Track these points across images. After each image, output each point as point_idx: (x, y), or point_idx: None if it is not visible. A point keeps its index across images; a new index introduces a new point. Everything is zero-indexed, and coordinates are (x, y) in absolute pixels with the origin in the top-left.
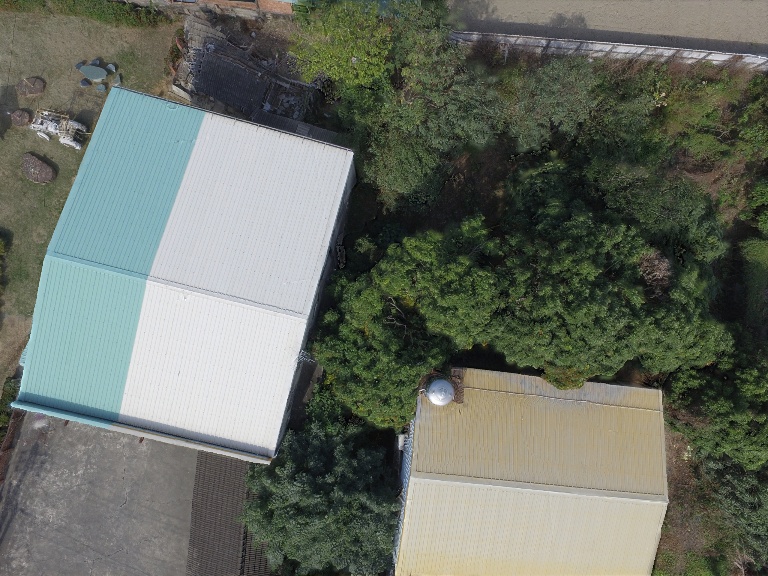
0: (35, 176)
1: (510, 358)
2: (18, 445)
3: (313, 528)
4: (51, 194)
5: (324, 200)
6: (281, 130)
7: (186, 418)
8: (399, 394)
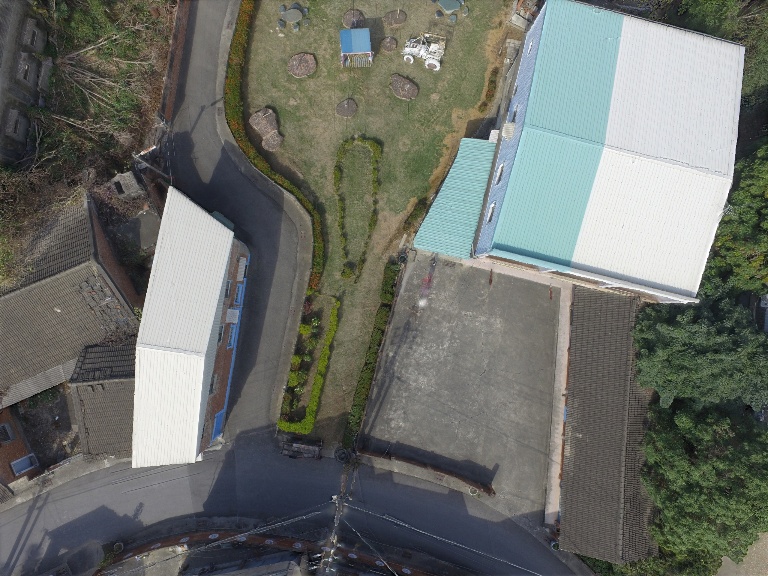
0: (404, 93)
1: None
2: (392, 322)
3: (719, 363)
4: (413, 109)
5: (728, 85)
6: (686, 29)
7: (625, 265)
8: None
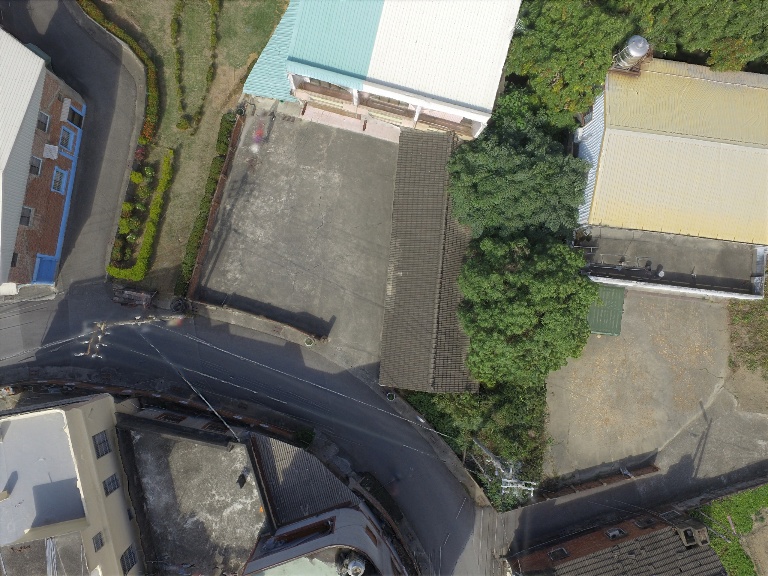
0: None
1: (687, 31)
2: (230, 176)
3: (519, 184)
4: None
5: None
6: None
7: (420, 81)
8: (603, 48)
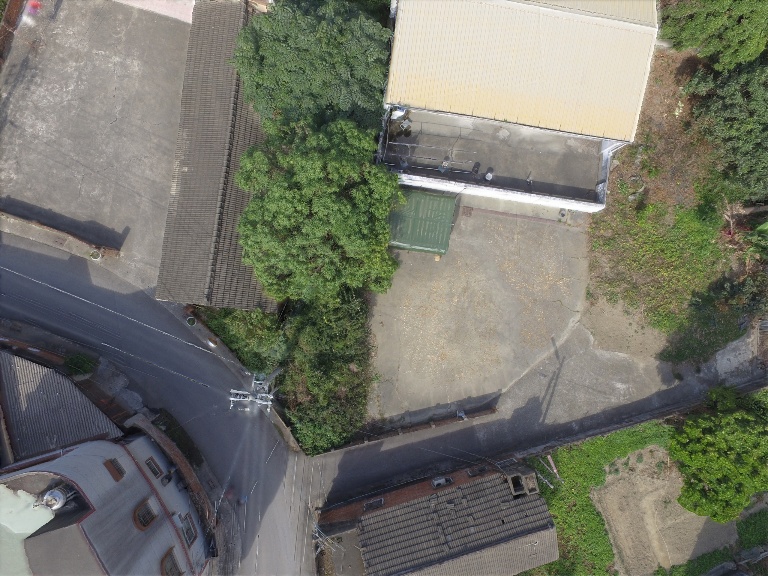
0: None
1: None
2: (8, 59)
3: (303, 53)
4: None
5: None
6: None
7: None
8: None
